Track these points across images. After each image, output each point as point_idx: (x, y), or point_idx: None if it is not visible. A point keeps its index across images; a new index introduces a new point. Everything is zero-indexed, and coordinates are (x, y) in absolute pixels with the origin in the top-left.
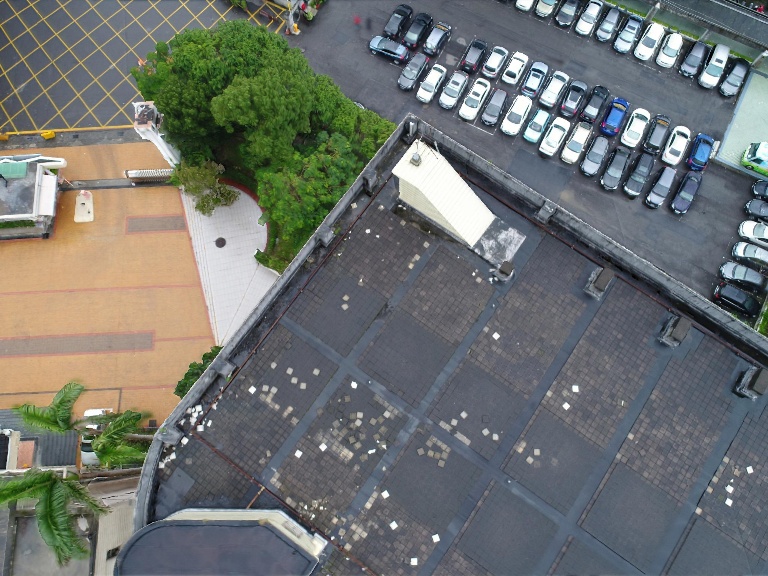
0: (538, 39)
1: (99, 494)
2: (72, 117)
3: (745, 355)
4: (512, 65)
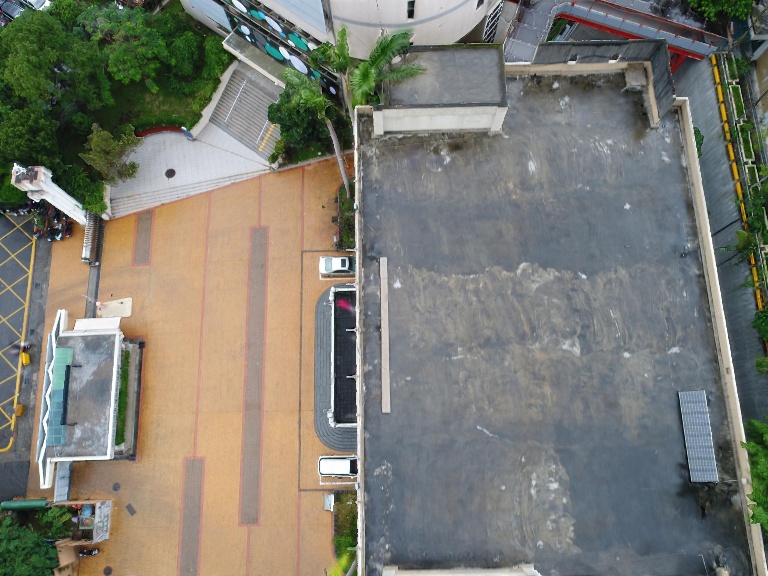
0: None
1: None
2: (8, 338)
3: None
4: None
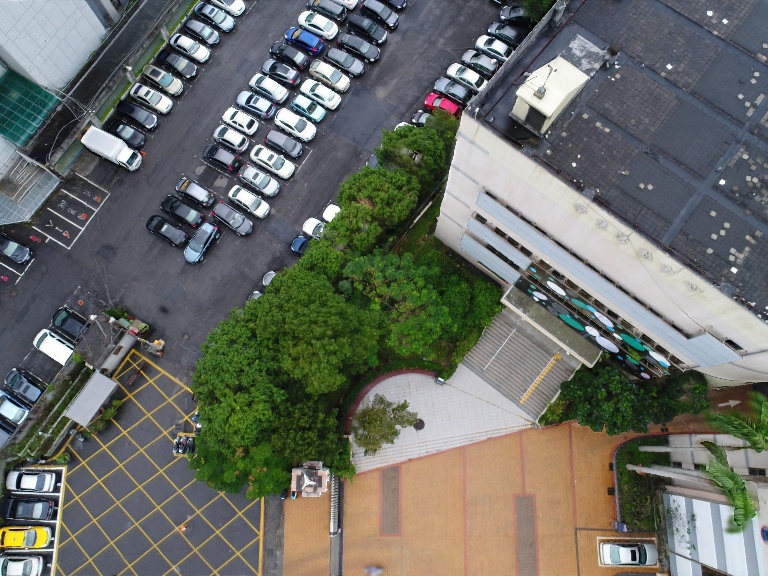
0: (207, 98)
1: (749, 489)
2: None
3: None
4: (241, 121)
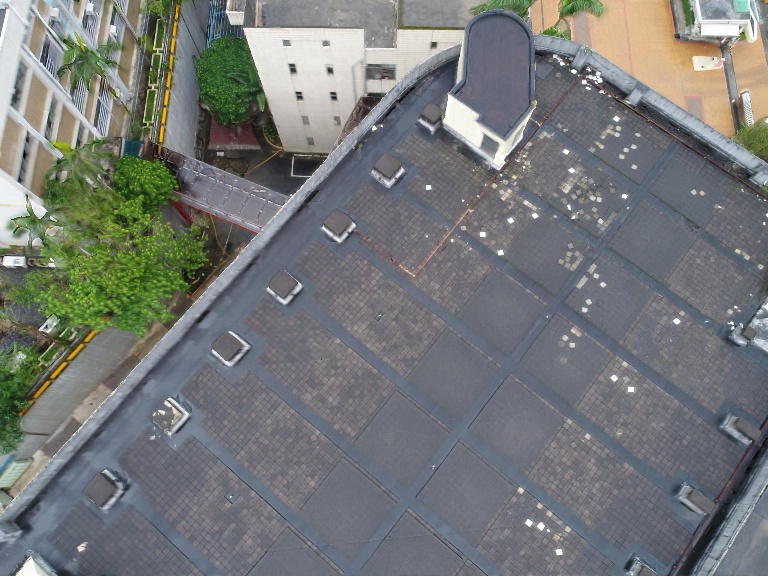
0: None
1: None
2: None
3: (674, 574)
4: None
